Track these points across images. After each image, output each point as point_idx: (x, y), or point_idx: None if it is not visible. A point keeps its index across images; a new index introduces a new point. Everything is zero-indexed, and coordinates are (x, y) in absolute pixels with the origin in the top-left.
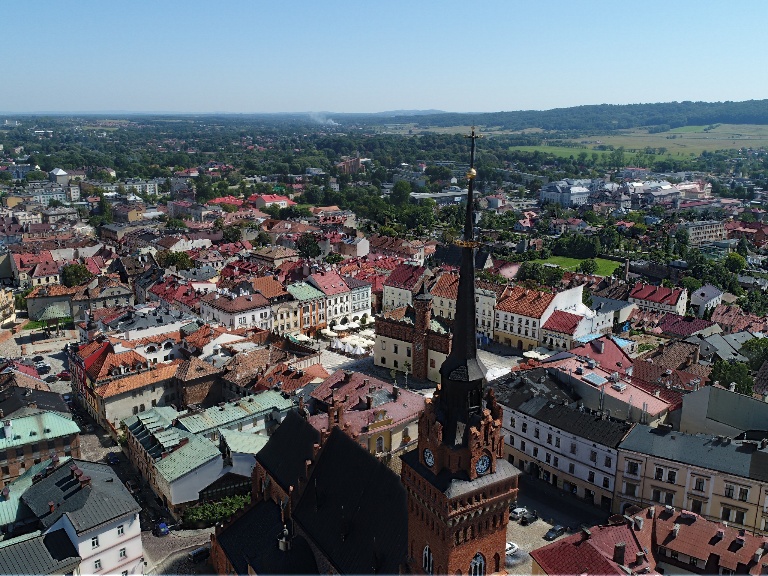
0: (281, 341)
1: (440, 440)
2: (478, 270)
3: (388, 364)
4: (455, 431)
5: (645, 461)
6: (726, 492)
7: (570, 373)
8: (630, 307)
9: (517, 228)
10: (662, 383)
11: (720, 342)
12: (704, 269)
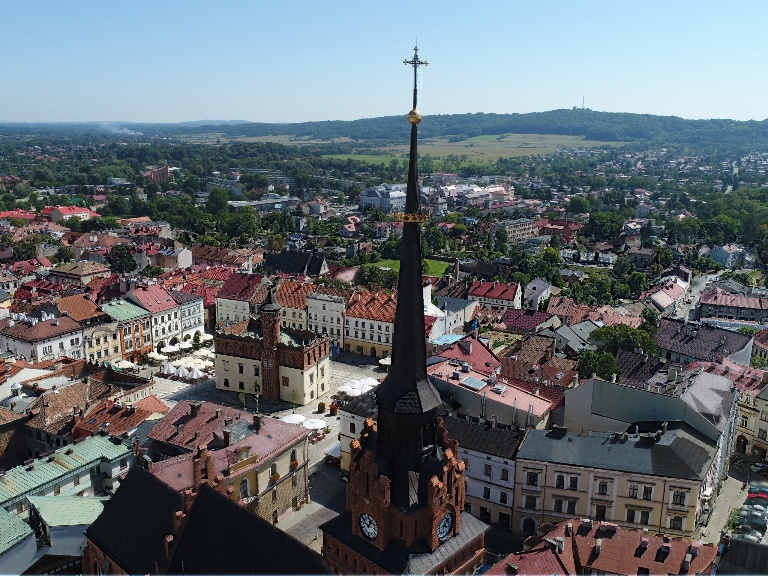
0: (101, 372)
1: (387, 501)
2: (314, 276)
3: (232, 387)
4: (407, 485)
5: (545, 469)
6: (630, 493)
7: (447, 379)
8: (473, 305)
9: (343, 233)
10: (531, 380)
11: (569, 333)
12: (529, 264)
